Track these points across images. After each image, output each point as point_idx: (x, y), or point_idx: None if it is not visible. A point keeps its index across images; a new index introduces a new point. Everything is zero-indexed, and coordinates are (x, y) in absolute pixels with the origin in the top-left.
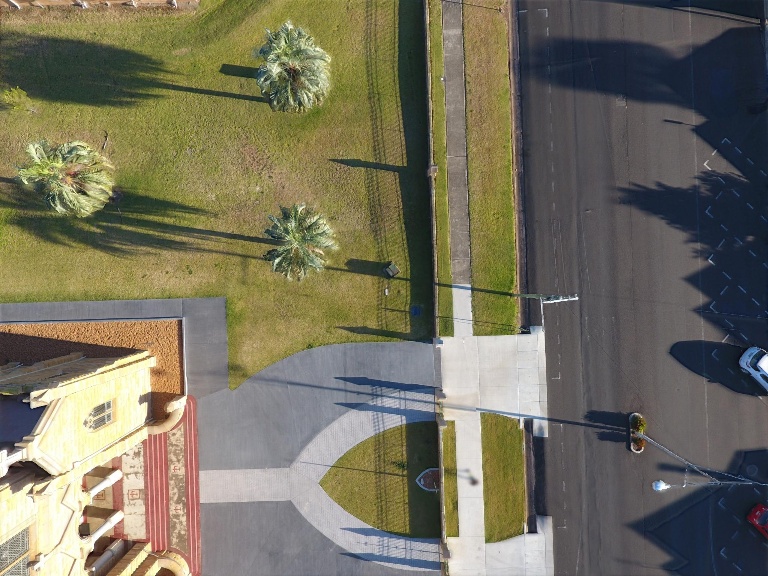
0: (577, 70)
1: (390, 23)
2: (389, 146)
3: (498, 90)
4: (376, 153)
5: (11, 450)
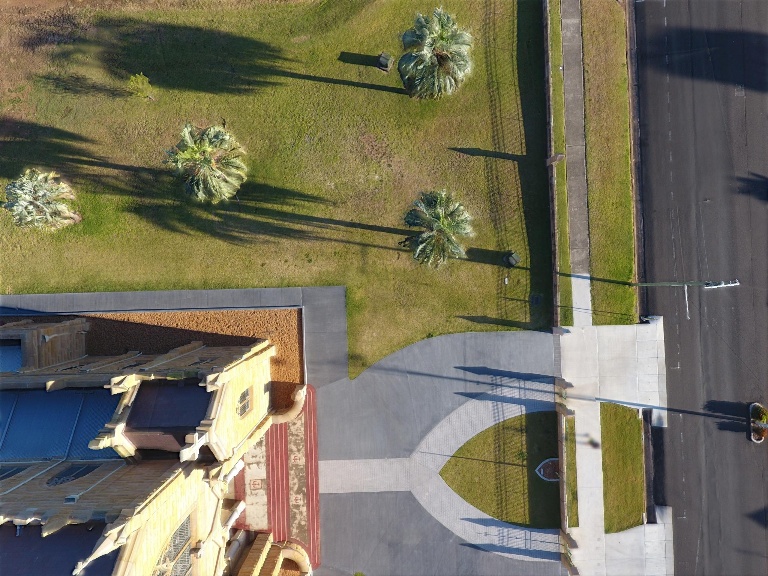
0: (695, 60)
1: (509, 12)
2: (508, 135)
3: (616, 79)
4: (495, 142)
5: (182, 435)
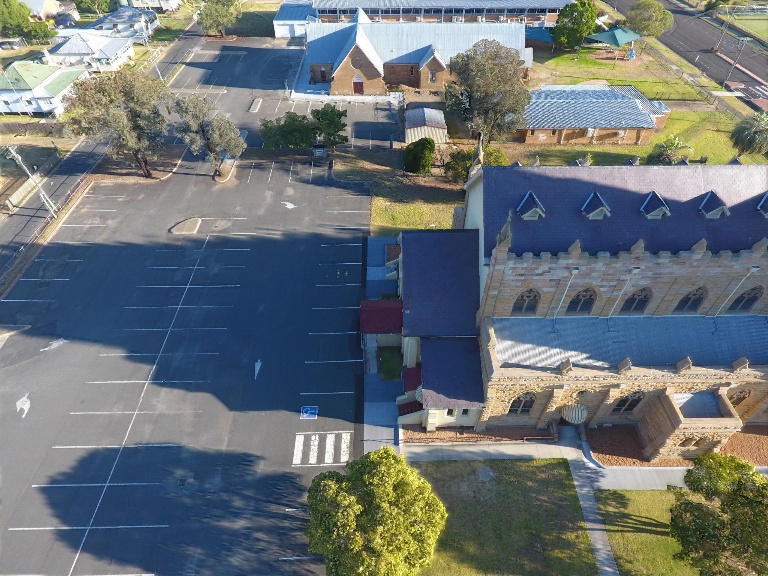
0: None
1: None
2: None
3: None
4: None
5: None
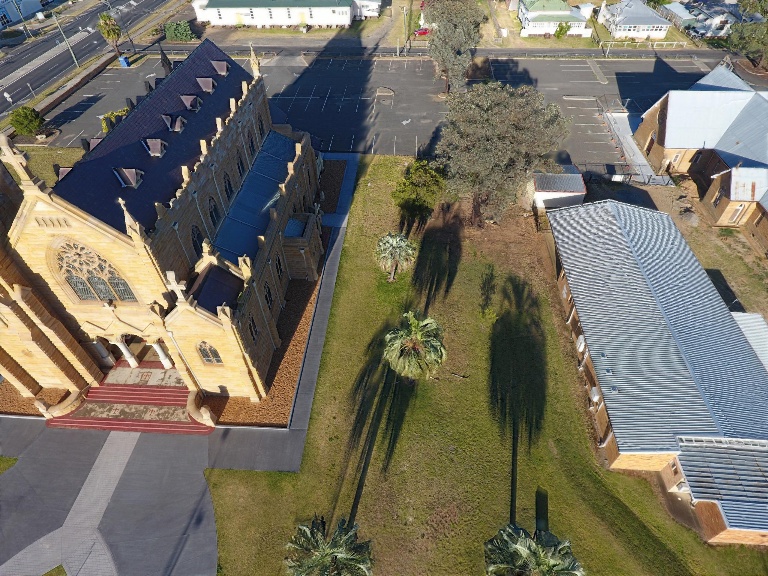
0: None
1: None
2: None
3: None
4: None
5: (194, 294)
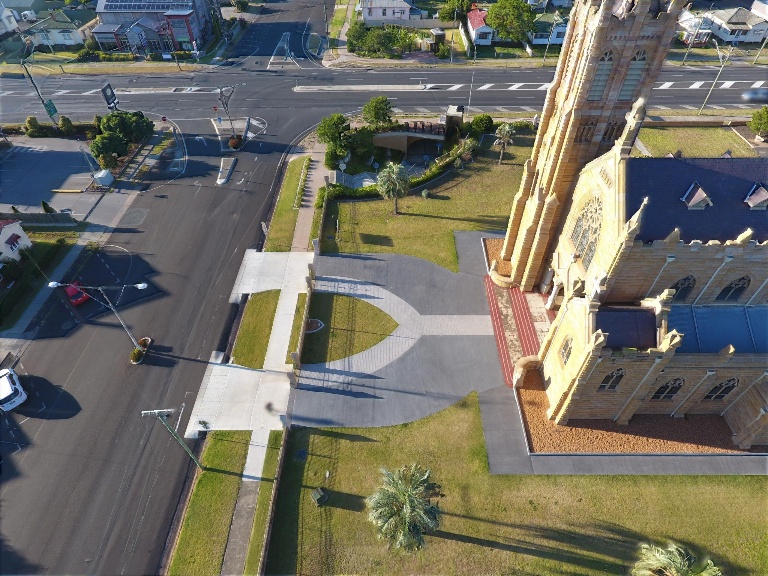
0: None
1: None
2: None
3: None
4: None
5: None
